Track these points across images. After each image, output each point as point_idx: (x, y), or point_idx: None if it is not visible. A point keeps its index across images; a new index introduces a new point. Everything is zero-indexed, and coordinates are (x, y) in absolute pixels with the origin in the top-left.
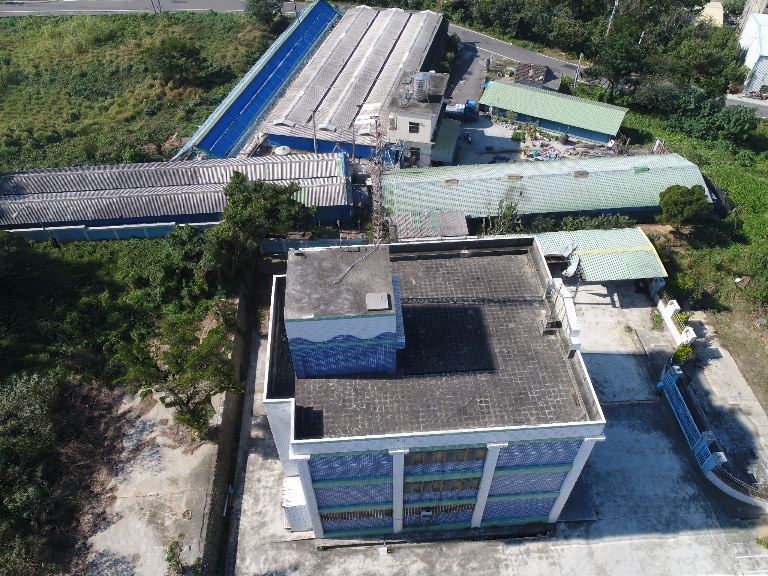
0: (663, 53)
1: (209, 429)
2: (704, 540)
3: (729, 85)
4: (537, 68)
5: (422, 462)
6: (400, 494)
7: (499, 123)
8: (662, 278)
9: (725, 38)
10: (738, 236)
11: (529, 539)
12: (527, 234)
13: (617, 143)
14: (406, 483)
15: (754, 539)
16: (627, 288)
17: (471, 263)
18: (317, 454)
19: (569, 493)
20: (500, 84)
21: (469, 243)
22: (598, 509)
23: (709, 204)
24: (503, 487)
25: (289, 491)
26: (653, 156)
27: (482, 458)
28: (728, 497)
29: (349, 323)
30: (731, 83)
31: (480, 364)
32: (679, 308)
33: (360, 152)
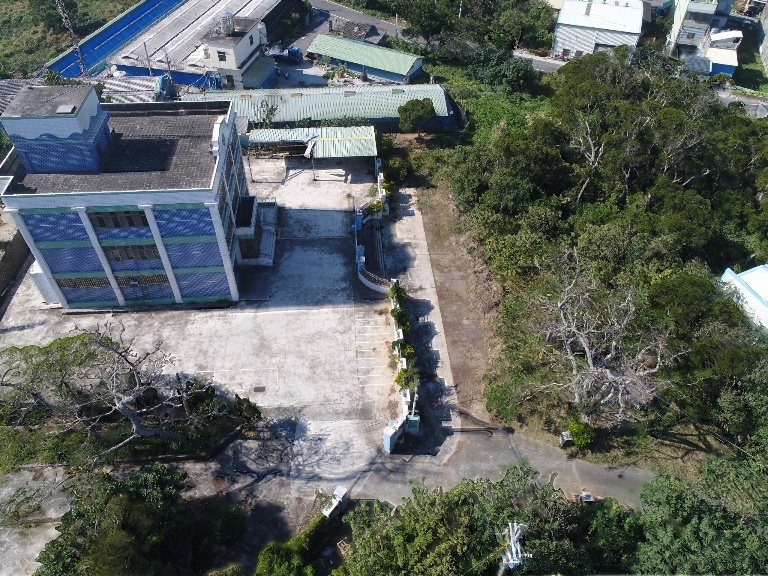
0: (489, 23)
1: (1, 243)
2: (338, 311)
3: (516, 42)
4: (361, 26)
5: (106, 226)
6: (103, 259)
7: (318, 66)
8: (380, 160)
9: (538, 11)
10: (468, 142)
11: (215, 310)
12: (285, 129)
13: (404, 80)
14: (104, 248)
15: (373, 310)
16: (361, 171)
17: (185, 118)
18: (25, 211)
19: (230, 266)
20: (325, 36)
21: (184, 104)
22: (272, 294)
23: (433, 112)
24: (180, 259)
25: (36, 266)
26: (418, 85)
27: (148, 225)
28: (368, 289)
29: (46, 123)
30: (517, 40)
31: (157, 168)
32: (382, 178)
33: (189, 80)
